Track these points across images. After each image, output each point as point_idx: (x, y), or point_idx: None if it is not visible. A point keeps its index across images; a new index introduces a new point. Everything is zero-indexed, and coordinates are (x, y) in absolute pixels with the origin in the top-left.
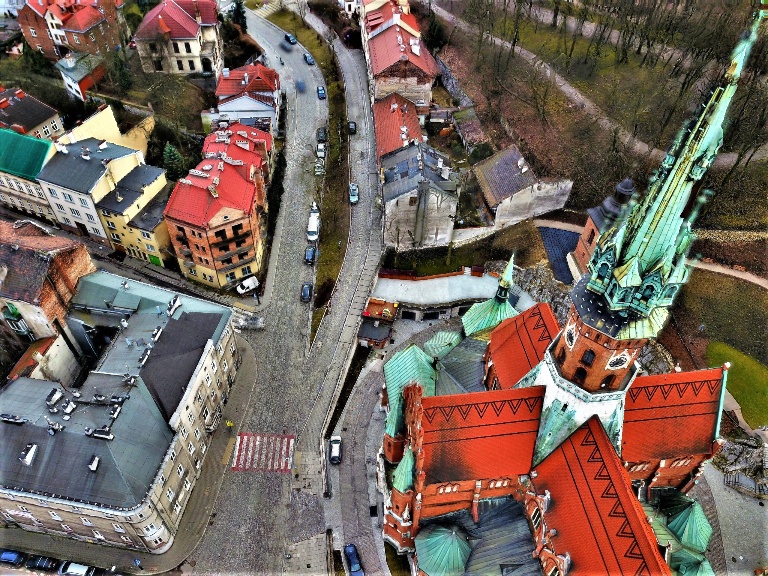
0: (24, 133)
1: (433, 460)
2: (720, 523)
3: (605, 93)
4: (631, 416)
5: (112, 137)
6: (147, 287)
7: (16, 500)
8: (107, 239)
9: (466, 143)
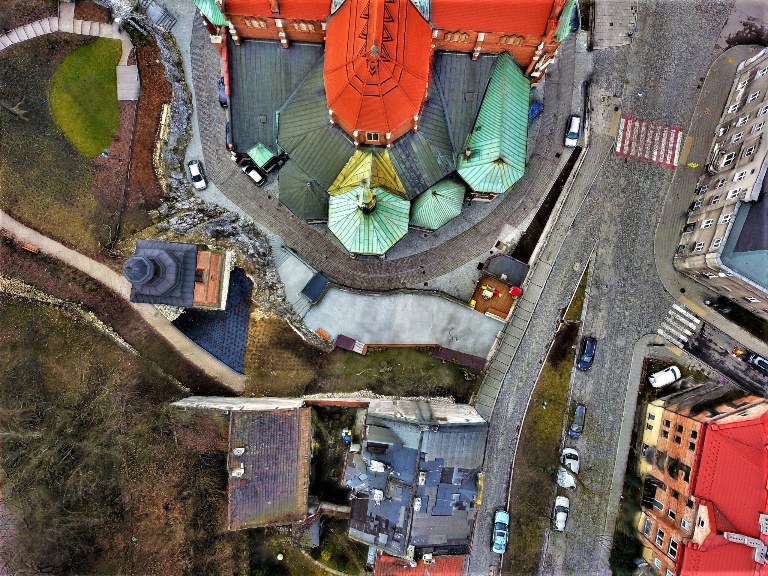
0: None
1: None
2: None
3: None
4: None
5: None
6: None
7: None
8: None
9: None
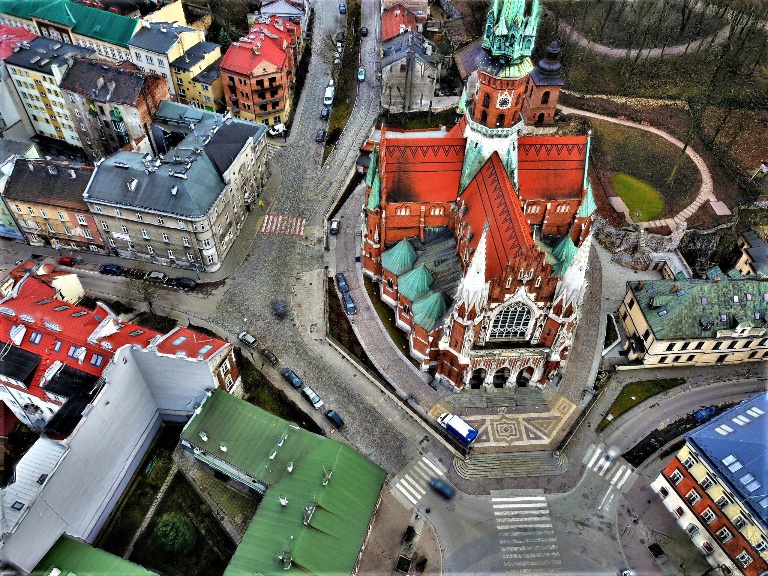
0: (118, 14)
1: (393, 185)
2: (603, 280)
3: (564, 6)
4: (525, 166)
5: (180, 25)
6: (207, 111)
7: (122, 218)
8: (175, 95)
9: (452, 43)
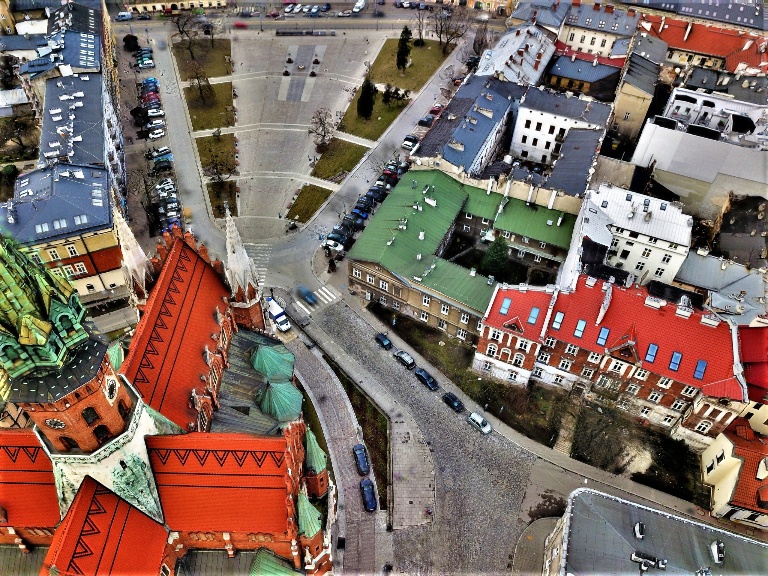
0: None
1: None
2: None
3: None
4: None
5: None
6: None
7: None
8: None
9: None
